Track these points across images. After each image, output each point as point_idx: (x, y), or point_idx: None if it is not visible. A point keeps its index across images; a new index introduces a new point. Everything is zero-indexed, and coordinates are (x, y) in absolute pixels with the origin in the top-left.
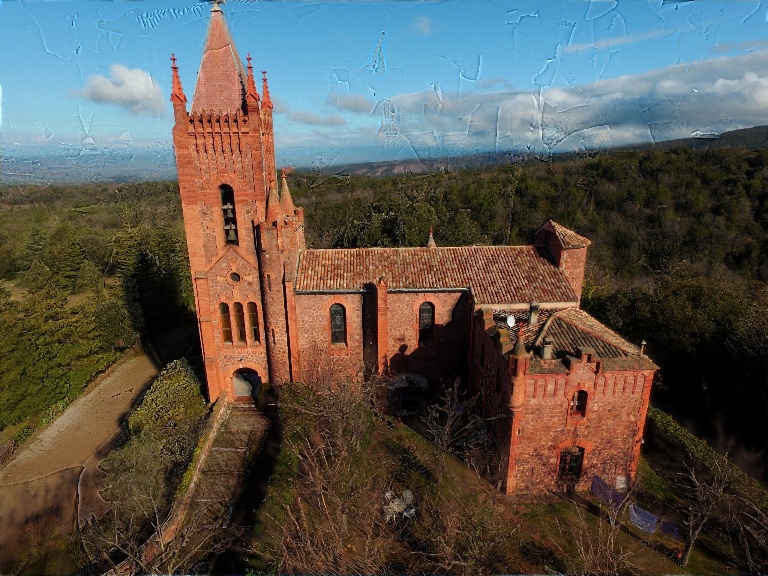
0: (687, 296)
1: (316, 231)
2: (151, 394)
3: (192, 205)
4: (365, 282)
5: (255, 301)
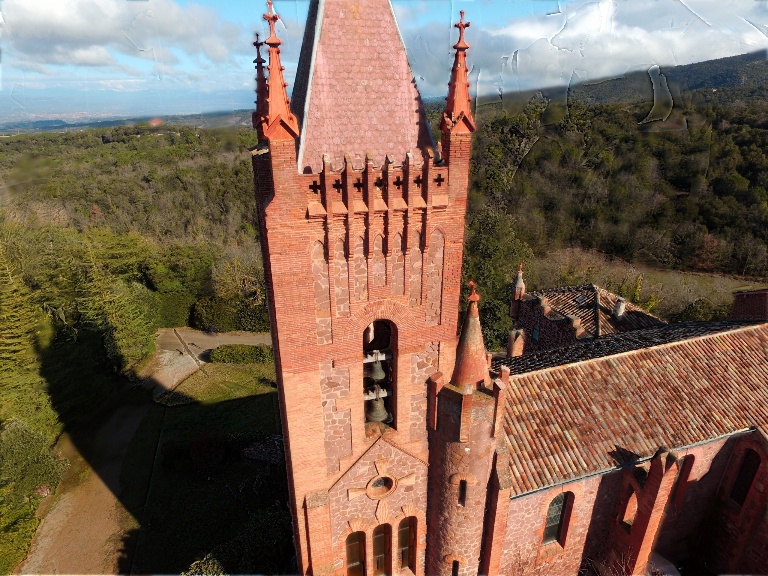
0: None
1: None
2: None
3: (306, 373)
4: (609, 448)
5: (415, 513)
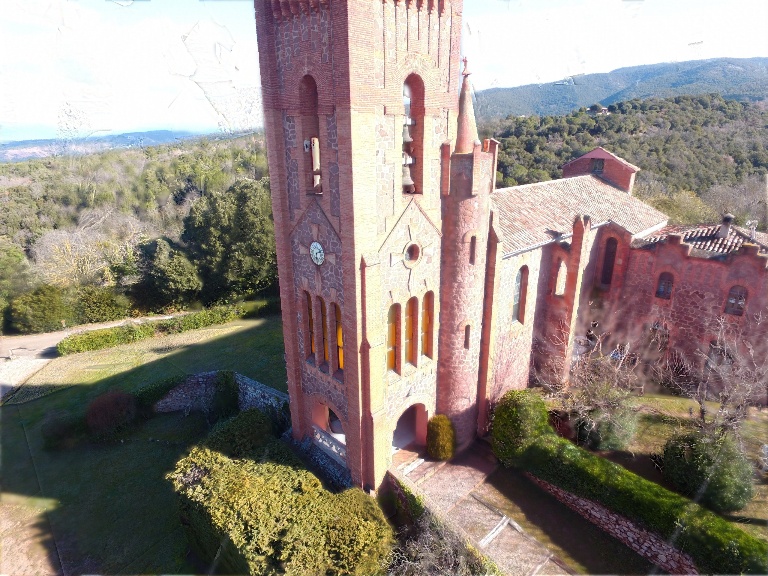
0: (663, 209)
1: (64, 224)
2: (256, 536)
3: (366, 114)
4: (543, 230)
5: (433, 288)
